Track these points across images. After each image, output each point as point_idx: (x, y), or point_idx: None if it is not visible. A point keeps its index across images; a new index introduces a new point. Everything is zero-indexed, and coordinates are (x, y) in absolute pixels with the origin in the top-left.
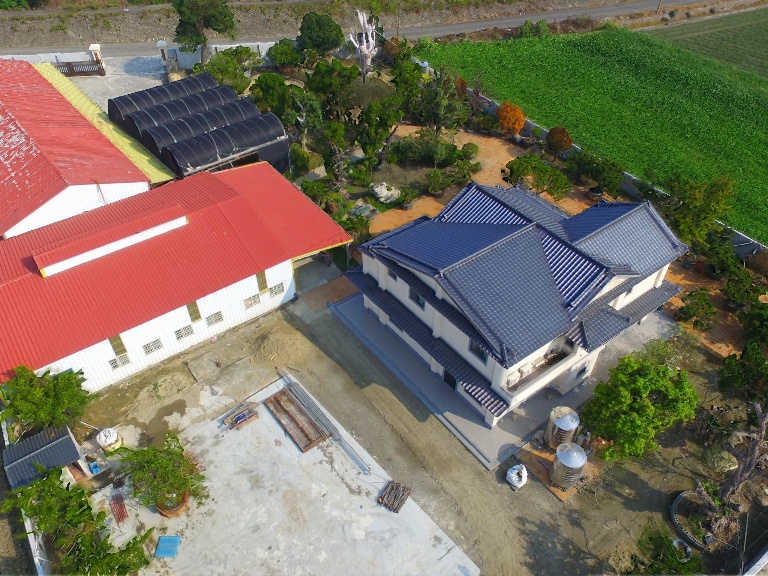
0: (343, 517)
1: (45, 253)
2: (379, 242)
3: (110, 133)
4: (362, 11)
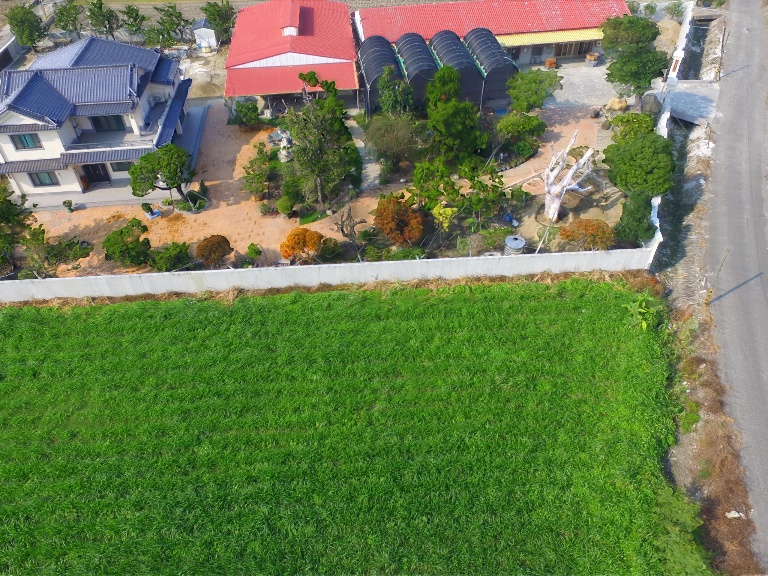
0: None
1: None
2: None
3: None
4: None
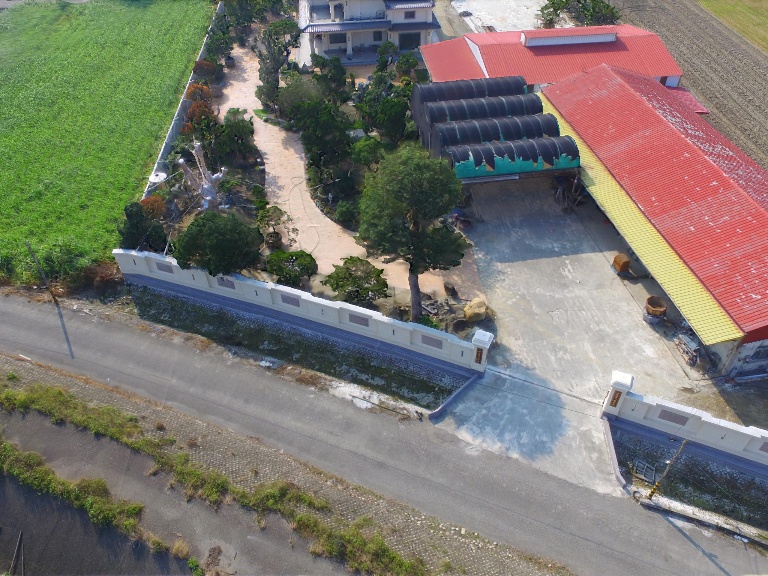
0: (487, 15)
1: (610, 27)
2: (424, 2)
3: (578, 149)
4: (0, 379)
